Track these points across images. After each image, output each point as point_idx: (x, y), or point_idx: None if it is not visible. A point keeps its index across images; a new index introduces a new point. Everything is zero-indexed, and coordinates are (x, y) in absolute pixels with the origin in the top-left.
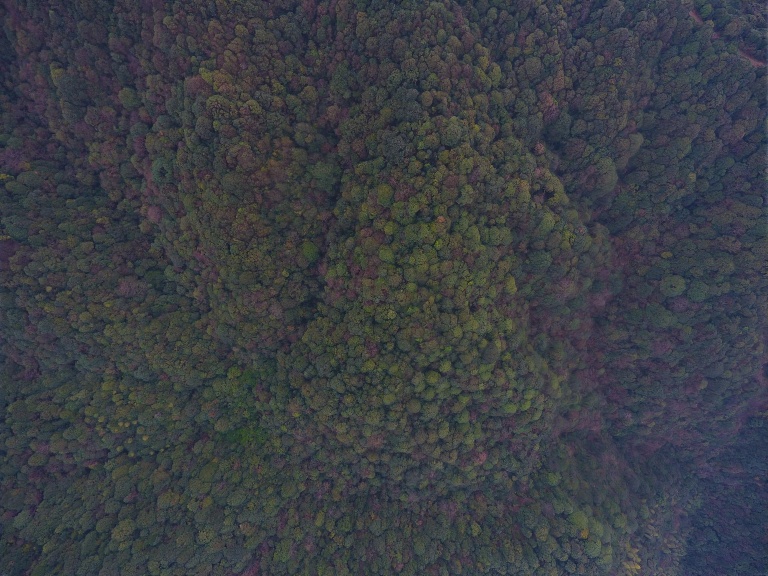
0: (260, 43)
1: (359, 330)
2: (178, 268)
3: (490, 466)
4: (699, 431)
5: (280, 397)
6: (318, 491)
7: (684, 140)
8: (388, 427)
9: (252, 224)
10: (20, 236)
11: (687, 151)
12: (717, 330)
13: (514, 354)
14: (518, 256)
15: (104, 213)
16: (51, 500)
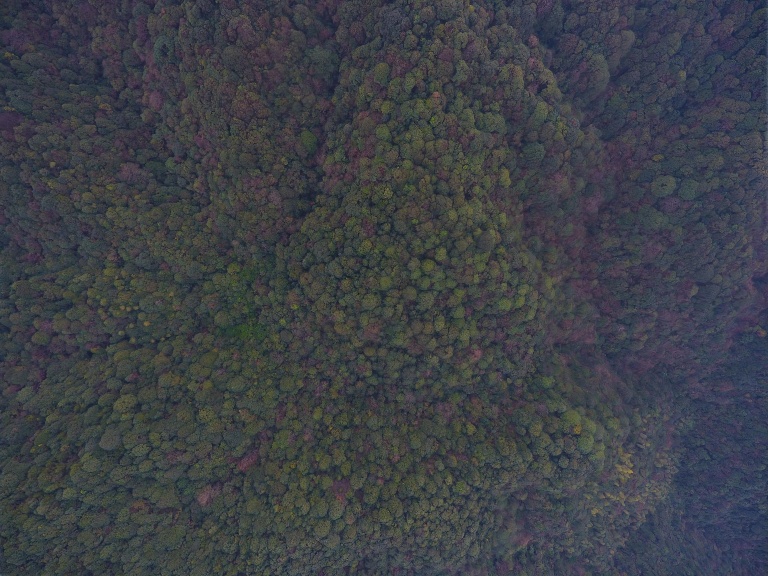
0: None
1: (356, 210)
2: (179, 158)
3: (485, 364)
4: (691, 348)
5: (279, 288)
6: (316, 389)
7: (674, 35)
8: (385, 313)
9: (252, 103)
10: (25, 110)
11: (677, 47)
12: (707, 229)
13: (508, 248)
14: (512, 150)
15: (106, 100)
16: (54, 378)
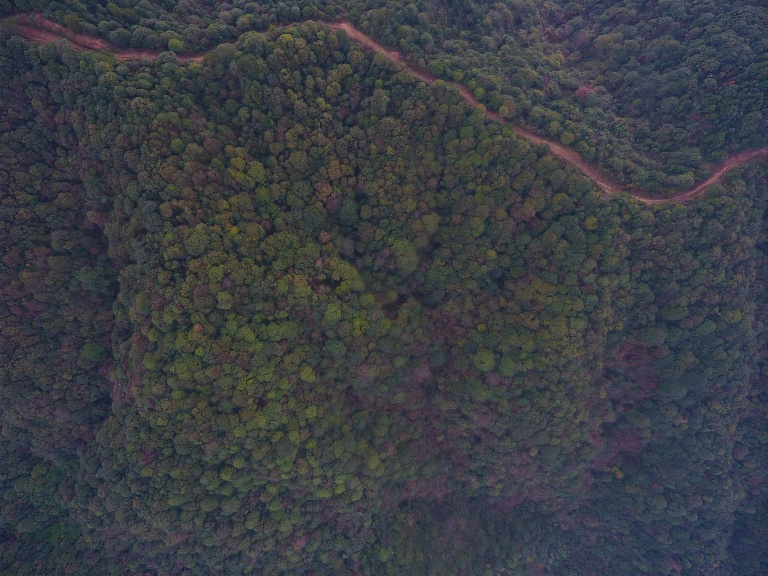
0: None
1: (133, 437)
2: None
3: (312, 549)
4: (552, 487)
5: (80, 497)
6: None
7: (475, 220)
8: None
9: (11, 337)
10: None
11: (481, 230)
12: (532, 403)
13: (320, 441)
14: (314, 344)
15: None
16: None
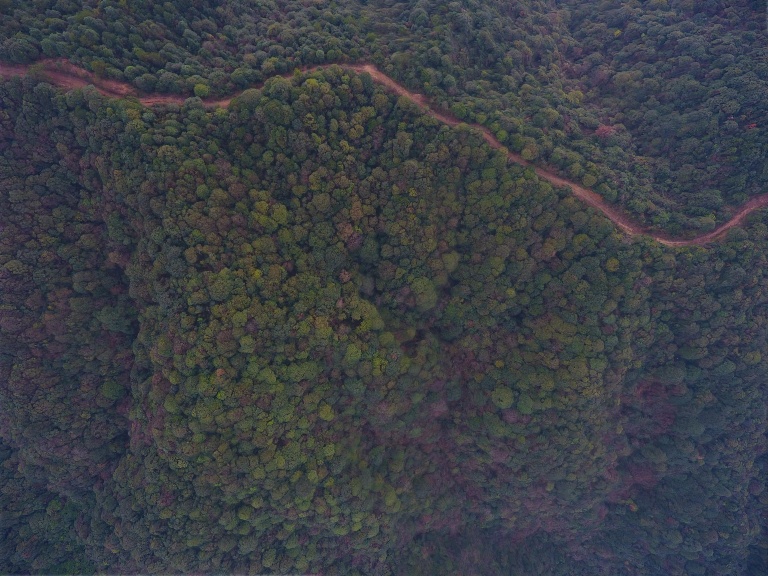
0: (17, 203)
1: (152, 479)
2: None
3: None
4: (566, 519)
5: (96, 535)
6: None
7: (495, 260)
8: None
9: (32, 379)
10: None
11: (501, 269)
12: (549, 440)
13: (337, 478)
14: (333, 382)
15: None
16: None
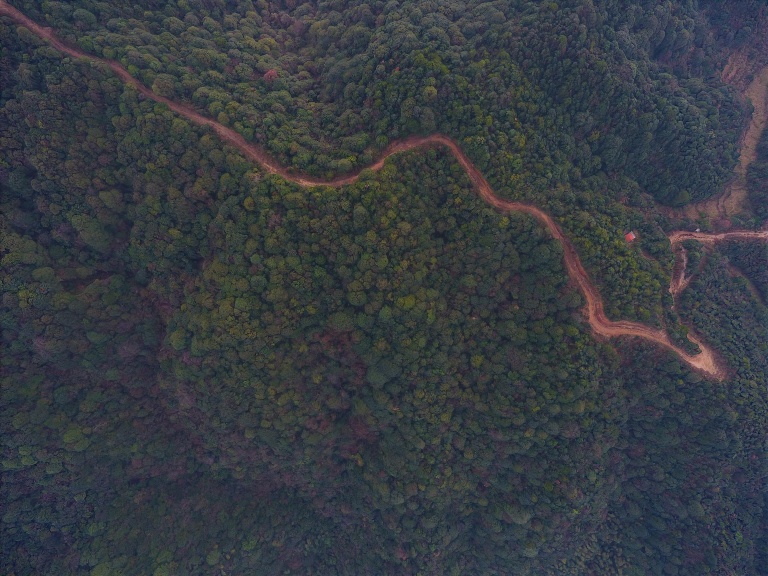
0: None
1: None
2: None
3: (8, 519)
4: (301, 473)
5: None
6: None
7: (147, 198)
8: None
9: None
10: None
11: (157, 208)
12: None
13: (1, 411)
14: None
15: None
16: None
